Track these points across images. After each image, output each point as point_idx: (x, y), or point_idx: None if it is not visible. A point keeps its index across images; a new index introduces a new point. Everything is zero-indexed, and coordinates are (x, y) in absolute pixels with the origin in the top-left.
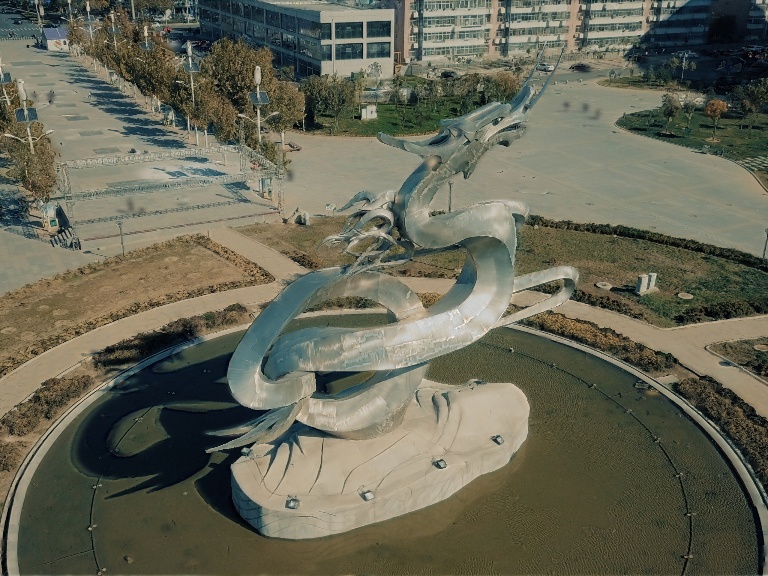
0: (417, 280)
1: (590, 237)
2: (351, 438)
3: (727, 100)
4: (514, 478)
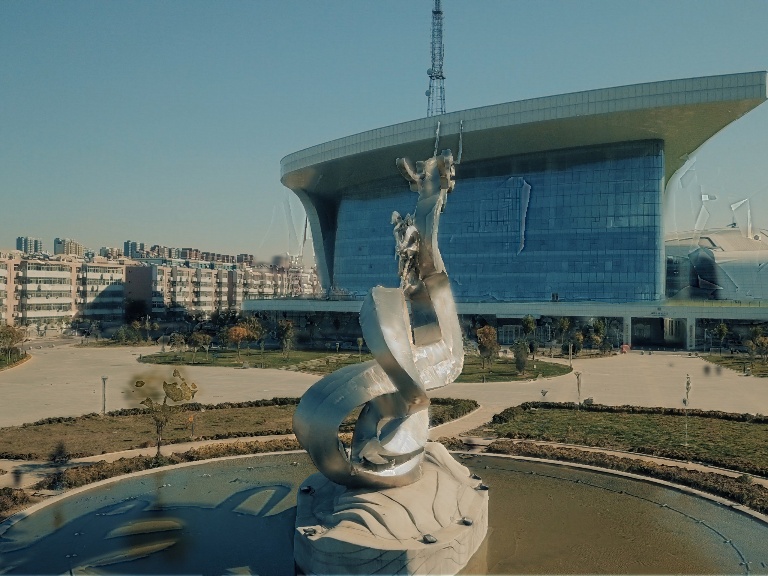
0: (168, 447)
1: (260, 409)
2: (402, 485)
3: (218, 340)
4: None
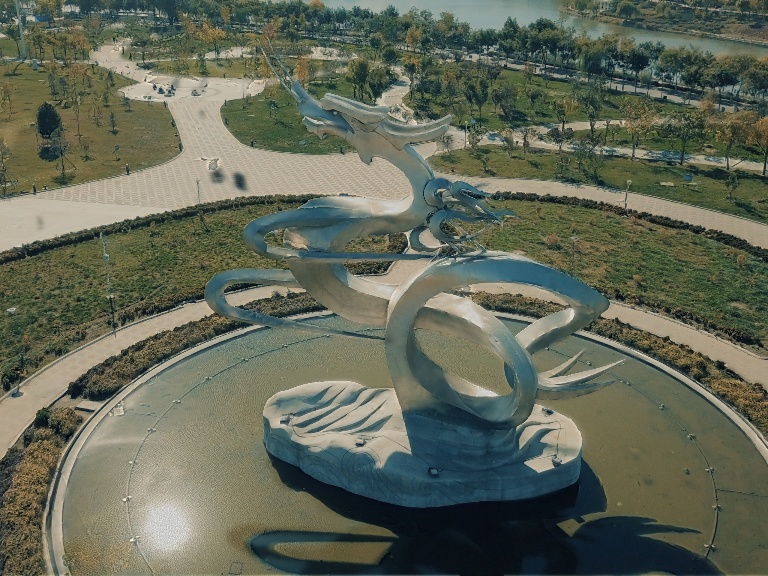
0: None
1: None
2: None
3: None
4: None
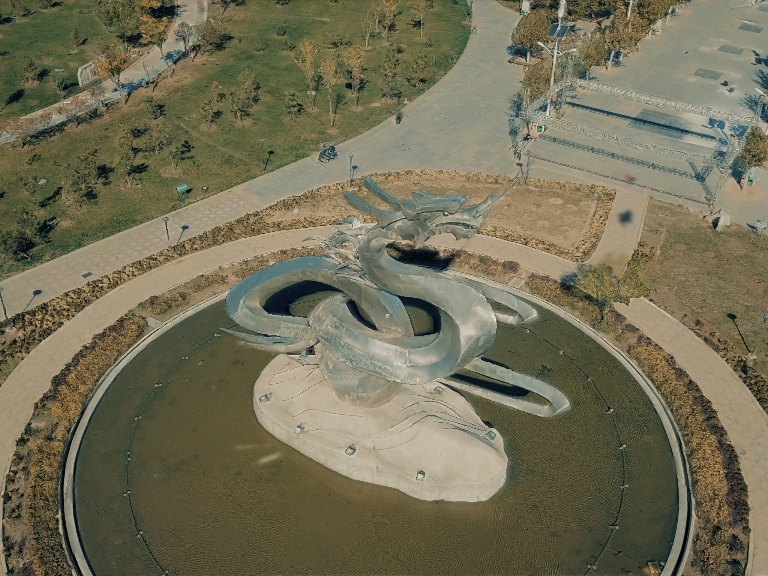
0: (691, 337)
1: None
2: None
3: None
4: (466, 526)
